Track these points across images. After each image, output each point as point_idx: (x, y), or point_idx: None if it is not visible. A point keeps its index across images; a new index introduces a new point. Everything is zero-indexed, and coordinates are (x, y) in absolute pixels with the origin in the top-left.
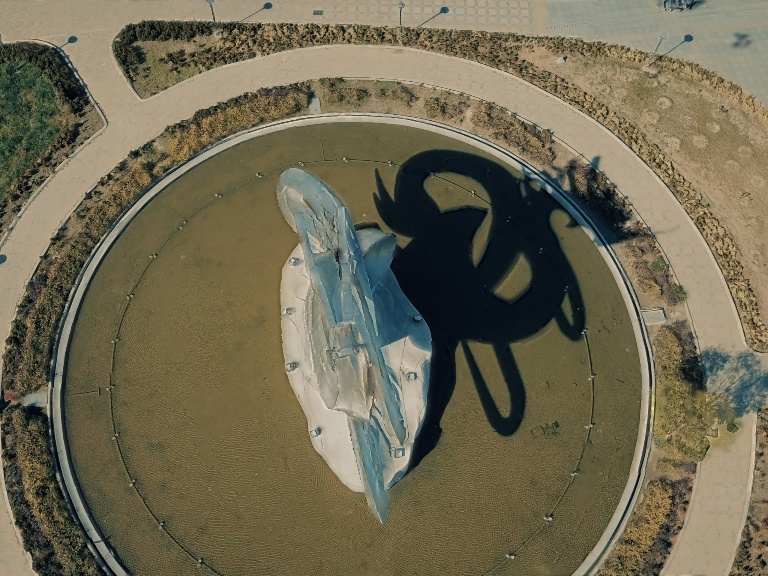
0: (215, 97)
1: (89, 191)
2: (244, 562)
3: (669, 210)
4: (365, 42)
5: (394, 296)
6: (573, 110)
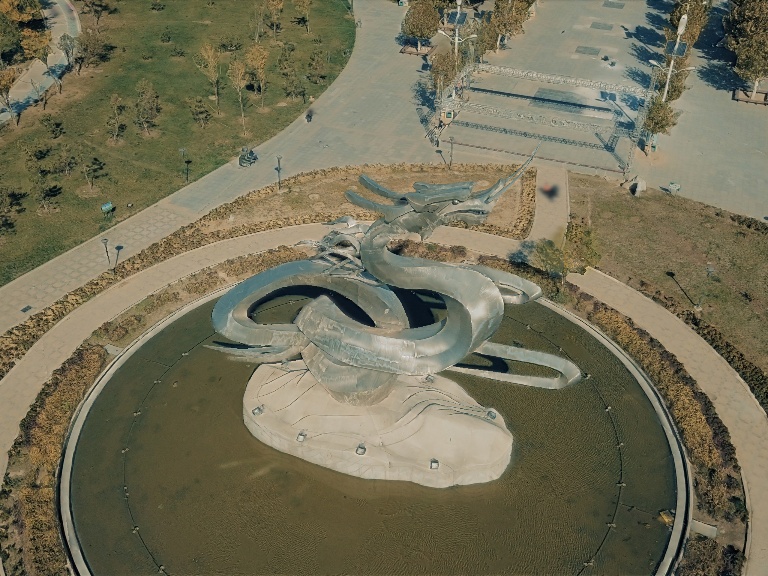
0: (19, 408)
1: None
2: None
3: None
4: (92, 295)
5: None
6: (277, 230)
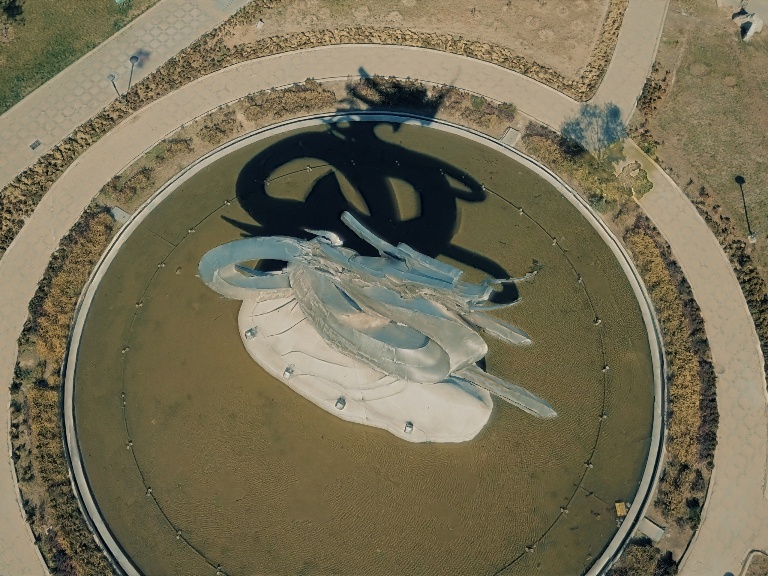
0: (28, 283)
1: (11, 454)
2: (460, 567)
3: (443, 62)
4: (102, 134)
5: None
6: (308, 51)
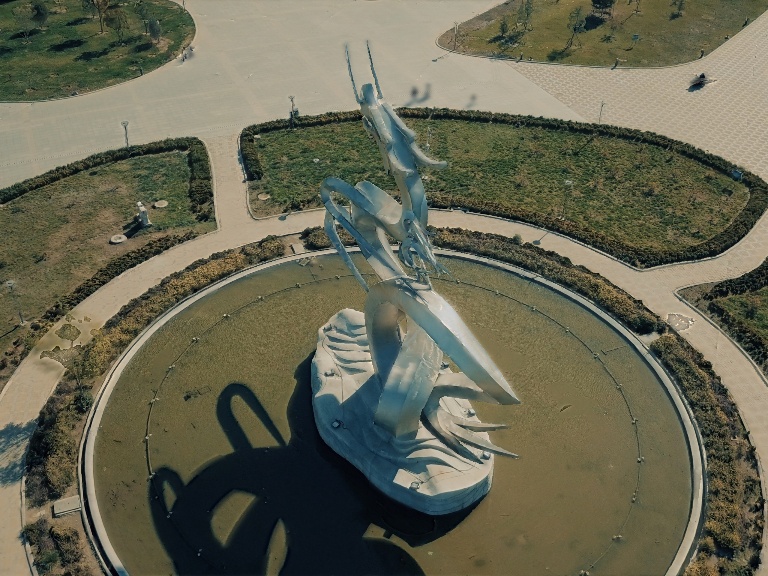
0: None
1: (766, 507)
2: None
3: None
4: None
5: (366, 447)
6: None
